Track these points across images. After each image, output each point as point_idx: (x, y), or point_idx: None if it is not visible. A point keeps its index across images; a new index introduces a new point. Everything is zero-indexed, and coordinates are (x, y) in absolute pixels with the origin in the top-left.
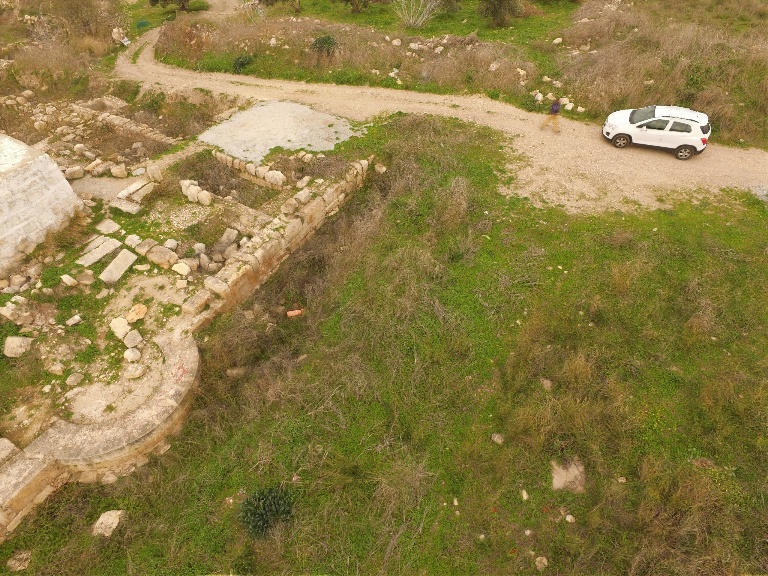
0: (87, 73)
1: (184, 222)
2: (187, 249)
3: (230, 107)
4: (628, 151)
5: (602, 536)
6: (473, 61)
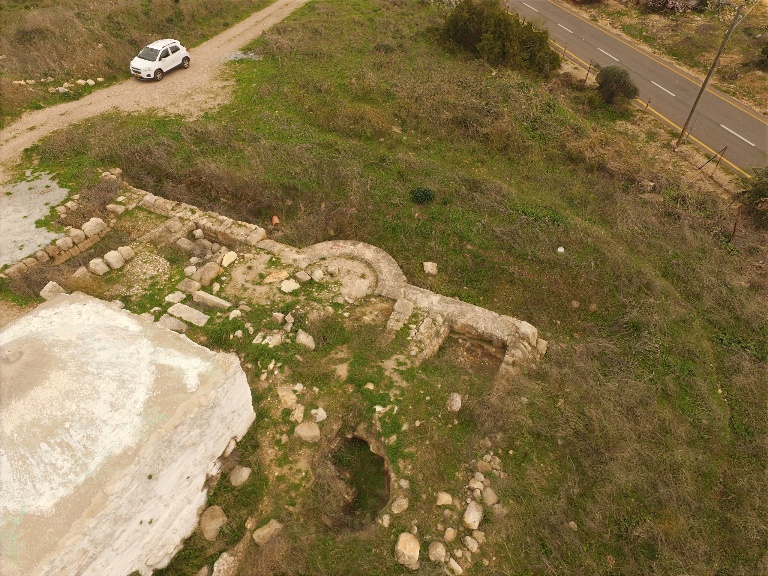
0: None
1: (158, 266)
2: None
3: None
4: (166, 79)
5: None
6: None
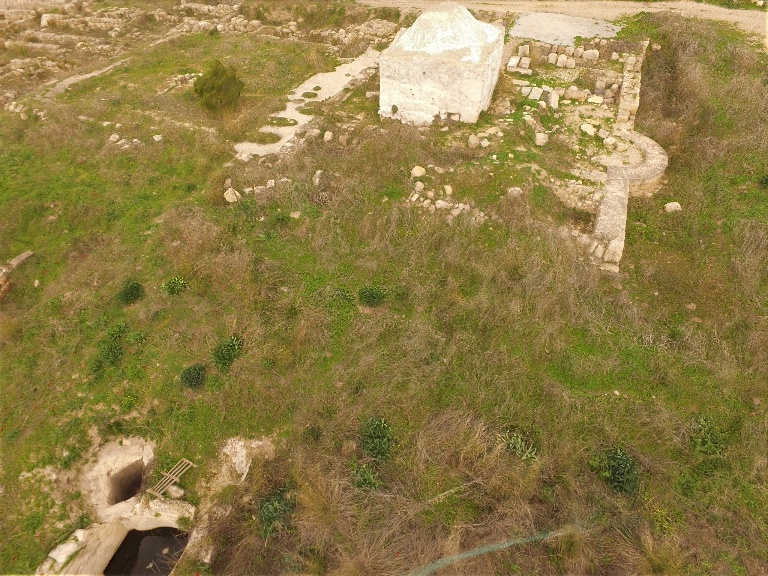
0: (340, 5)
1: (569, 77)
2: None
3: (491, 20)
4: None
5: None
6: None
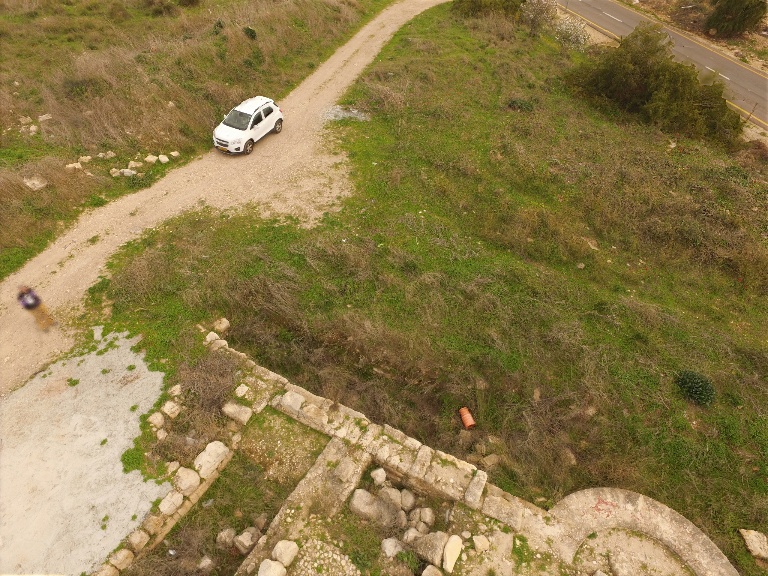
0: None
1: None
2: (397, 567)
3: None
4: (257, 150)
5: (618, 238)
6: (2, 196)
